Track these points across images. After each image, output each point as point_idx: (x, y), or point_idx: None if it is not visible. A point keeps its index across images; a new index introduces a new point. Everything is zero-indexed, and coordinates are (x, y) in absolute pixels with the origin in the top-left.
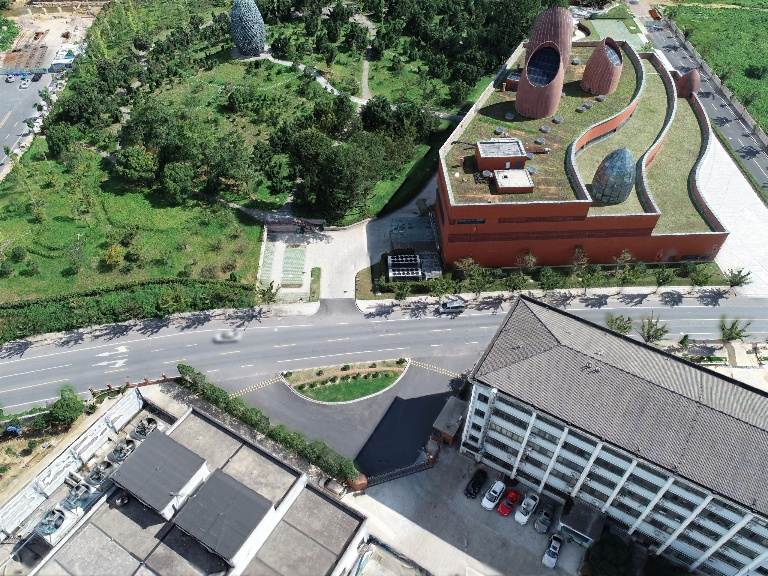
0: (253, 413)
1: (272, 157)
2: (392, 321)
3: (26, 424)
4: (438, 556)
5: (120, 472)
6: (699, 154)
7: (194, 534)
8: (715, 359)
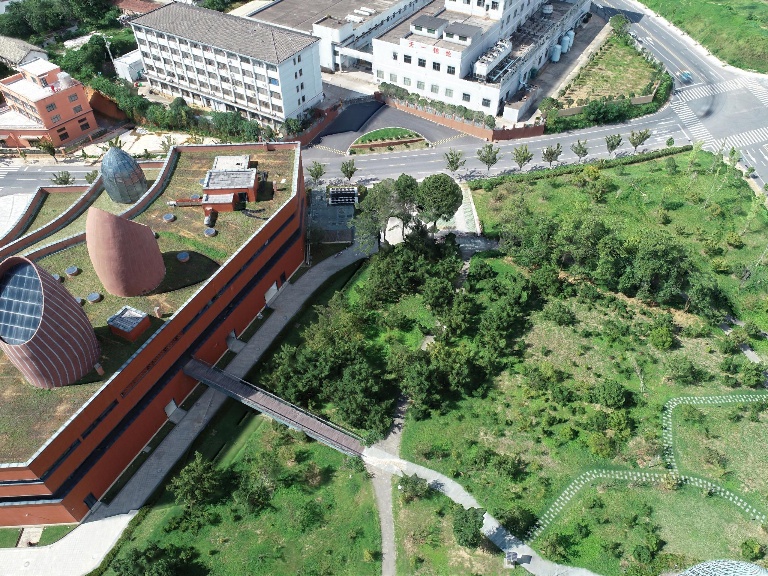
0: (439, 102)
1: None
2: (357, 176)
3: (570, 113)
4: (342, 83)
5: (478, 28)
6: None
7: (439, 18)
8: None
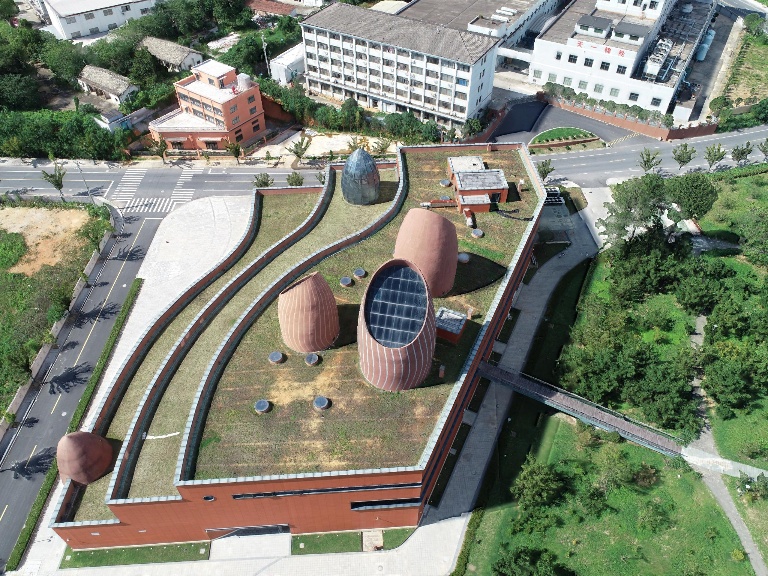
0: None
1: (762, 300)
2: None
3: (738, 112)
4: (497, 83)
5: (647, 27)
6: (195, 298)
7: None
8: (311, 158)
